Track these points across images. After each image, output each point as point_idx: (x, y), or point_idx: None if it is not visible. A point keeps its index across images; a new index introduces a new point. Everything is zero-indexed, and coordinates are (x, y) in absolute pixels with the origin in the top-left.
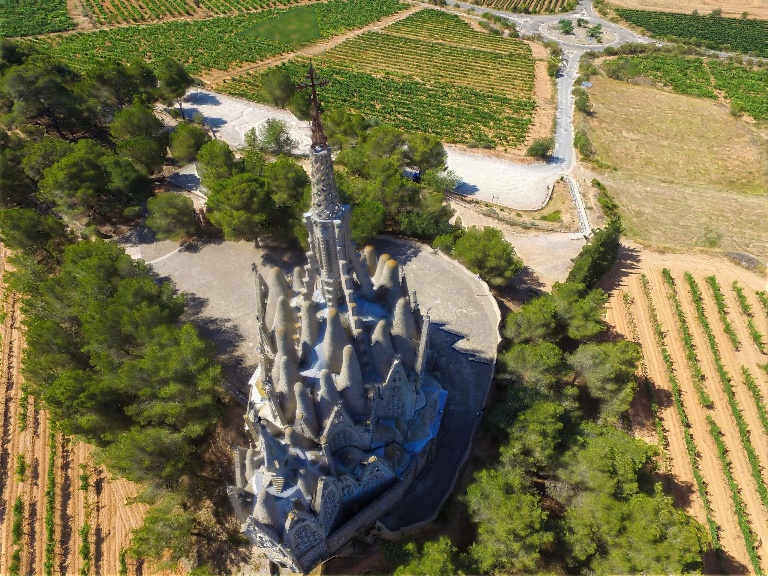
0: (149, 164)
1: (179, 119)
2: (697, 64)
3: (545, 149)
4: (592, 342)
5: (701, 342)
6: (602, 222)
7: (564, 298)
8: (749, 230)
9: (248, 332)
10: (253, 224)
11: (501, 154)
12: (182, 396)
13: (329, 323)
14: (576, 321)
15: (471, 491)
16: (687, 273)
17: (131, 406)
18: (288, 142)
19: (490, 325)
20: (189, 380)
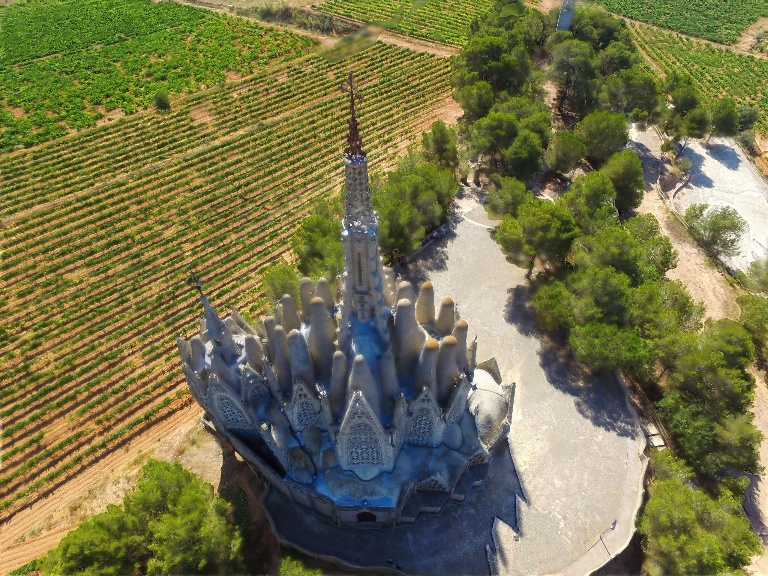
0: (561, 160)
1: (667, 154)
2: None
3: None
4: None
5: None
6: None
7: None
8: None
9: None
10: None
11: None
12: None
13: None
14: None
15: (286, 562)
16: None
17: None
18: (729, 244)
19: (557, 569)
20: None
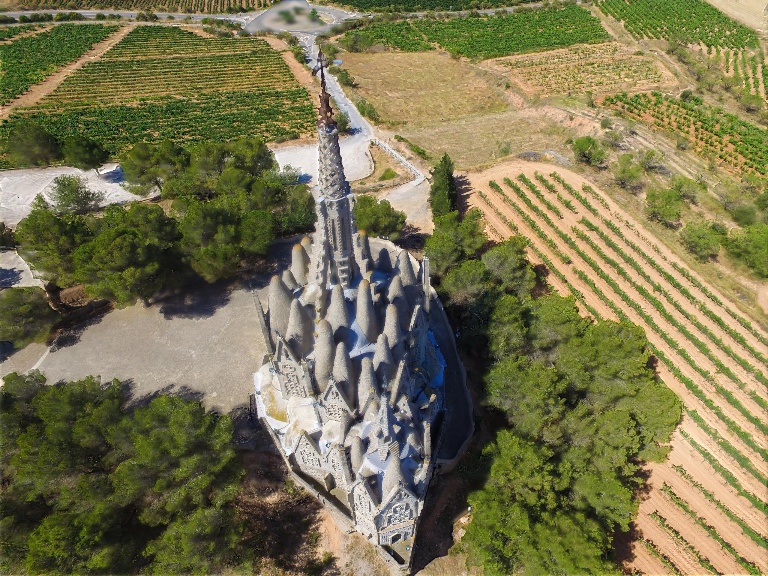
0: None
1: None
2: (406, 26)
3: (344, 124)
4: (488, 249)
5: (540, 222)
6: (426, 165)
7: (449, 227)
8: (516, 137)
9: (202, 385)
10: (145, 278)
11: (310, 140)
12: (198, 468)
13: (365, 294)
14: (467, 241)
15: None
16: (505, 179)
17: (143, 513)
18: (89, 197)
19: None
20: (196, 449)
